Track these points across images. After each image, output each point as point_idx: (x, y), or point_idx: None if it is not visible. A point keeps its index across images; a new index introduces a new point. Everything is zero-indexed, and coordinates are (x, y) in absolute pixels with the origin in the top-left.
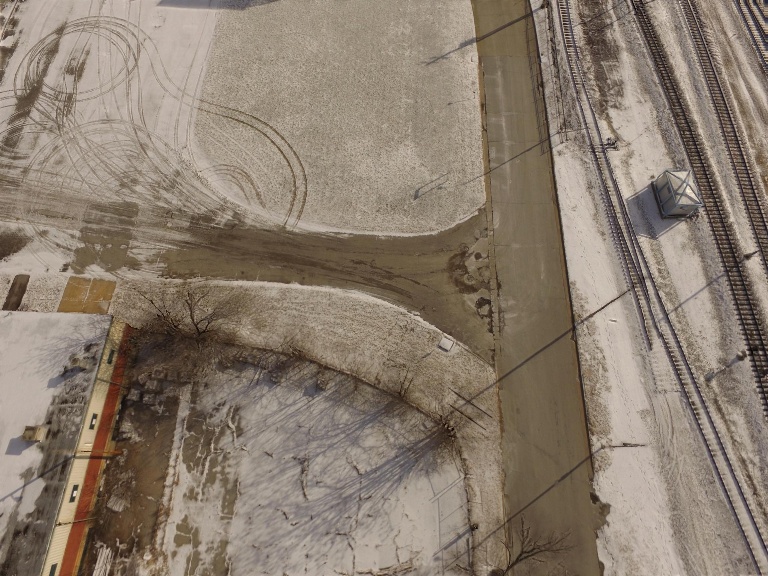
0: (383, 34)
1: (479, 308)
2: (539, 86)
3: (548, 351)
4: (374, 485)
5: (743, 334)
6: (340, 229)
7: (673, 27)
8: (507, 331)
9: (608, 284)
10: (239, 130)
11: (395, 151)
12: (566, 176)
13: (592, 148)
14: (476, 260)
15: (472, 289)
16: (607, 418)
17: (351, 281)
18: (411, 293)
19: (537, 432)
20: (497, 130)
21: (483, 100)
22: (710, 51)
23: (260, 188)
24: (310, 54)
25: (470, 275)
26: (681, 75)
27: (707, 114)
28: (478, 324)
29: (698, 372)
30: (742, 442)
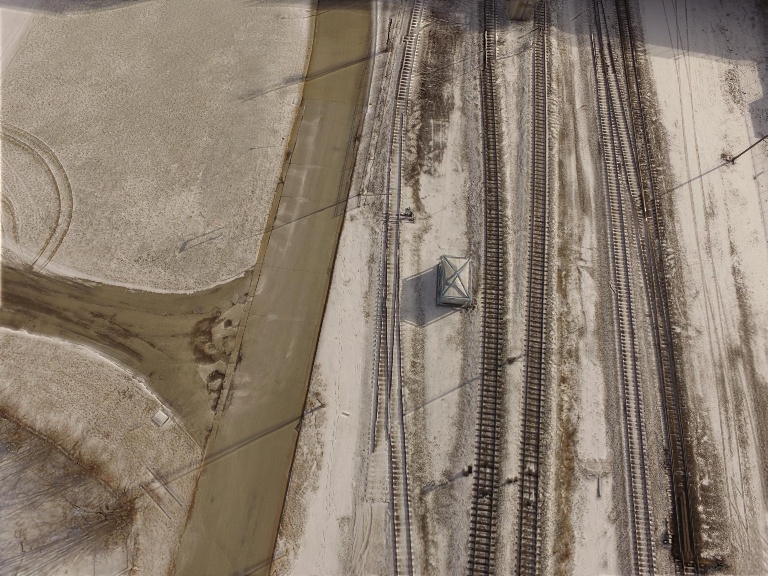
0: (207, 61)
1: (210, 382)
2: (356, 139)
3: (266, 439)
4: (34, 565)
5: (477, 447)
6: (90, 276)
7: (520, 89)
8: (230, 411)
9: (354, 372)
10: (17, 153)
11: (177, 195)
12: (350, 245)
13: (386, 217)
14: (224, 328)
15: (209, 360)
16: (302, 522)
17: (83, 336)
18: (142, 357)
19: (224, 528)
20: (295, 184)
21: (291, 148)
22: (549, 122)
23: (19, 220)
24: (121, 75)
25: (212, 344)
26: (510, 145)
27: (522, 193)
28: (203, 400)
29: (415, 483)
30: (438, 567)
